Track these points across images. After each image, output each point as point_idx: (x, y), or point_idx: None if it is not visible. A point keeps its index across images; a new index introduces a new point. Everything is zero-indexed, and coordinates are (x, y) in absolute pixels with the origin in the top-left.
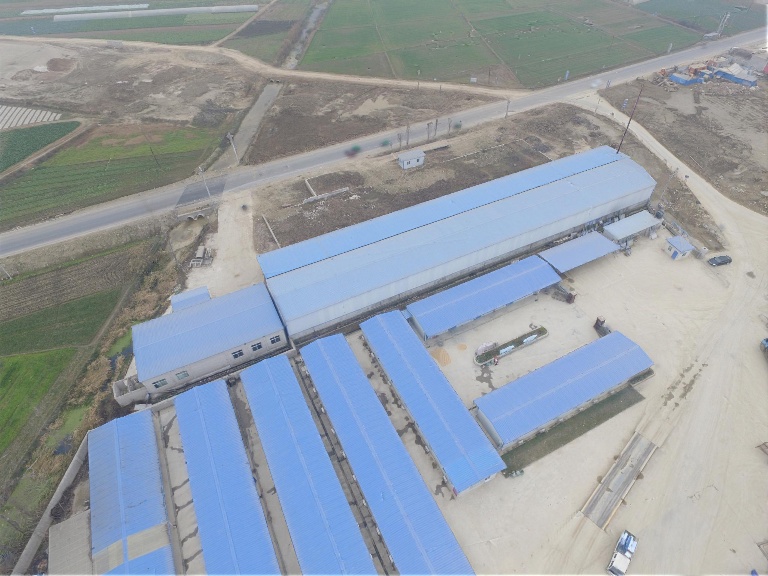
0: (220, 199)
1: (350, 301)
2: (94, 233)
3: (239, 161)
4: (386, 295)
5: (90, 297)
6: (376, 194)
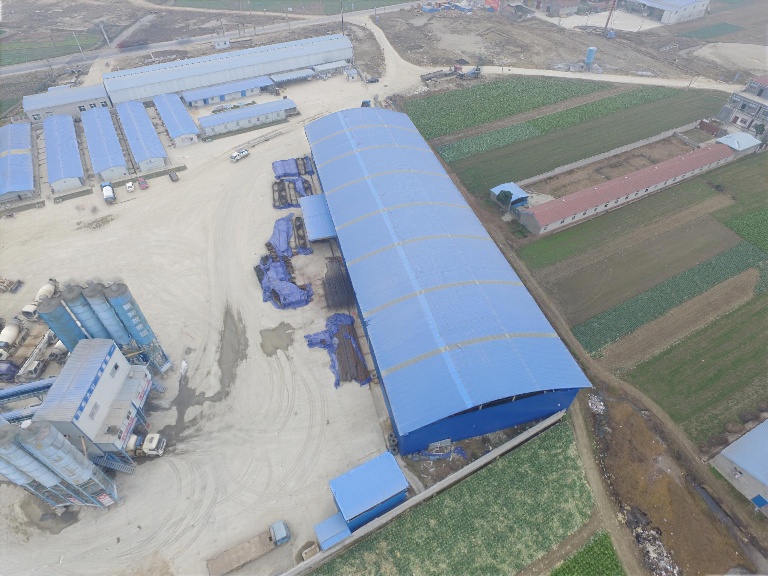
0: (93, 62)
1: (148, 87)
2: (9, 75)
3: (113, 48)
4: (173, 89)
5: (4, 100)
6: None
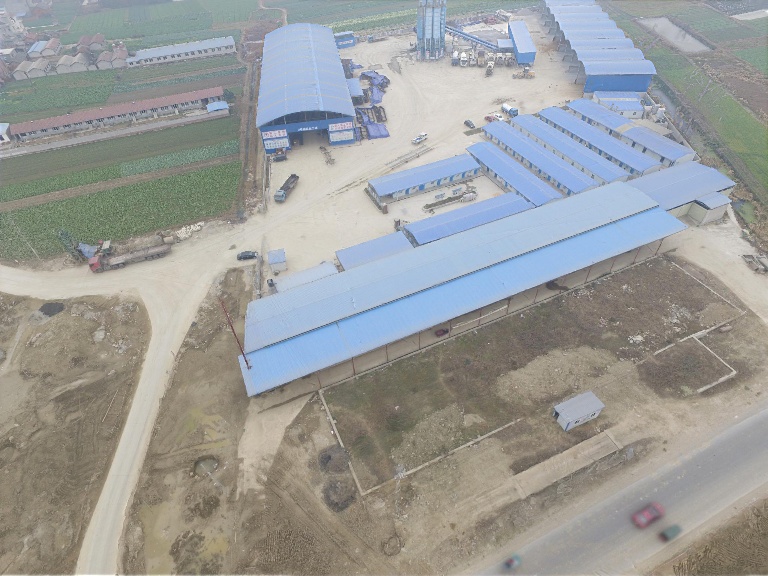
0: None
1: None
2: None
3: None
4: None
5: None
6: (608, 346)
